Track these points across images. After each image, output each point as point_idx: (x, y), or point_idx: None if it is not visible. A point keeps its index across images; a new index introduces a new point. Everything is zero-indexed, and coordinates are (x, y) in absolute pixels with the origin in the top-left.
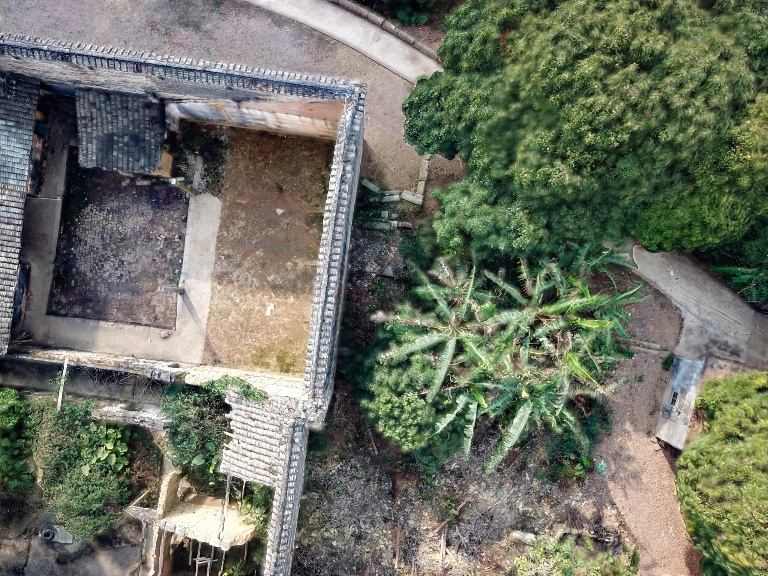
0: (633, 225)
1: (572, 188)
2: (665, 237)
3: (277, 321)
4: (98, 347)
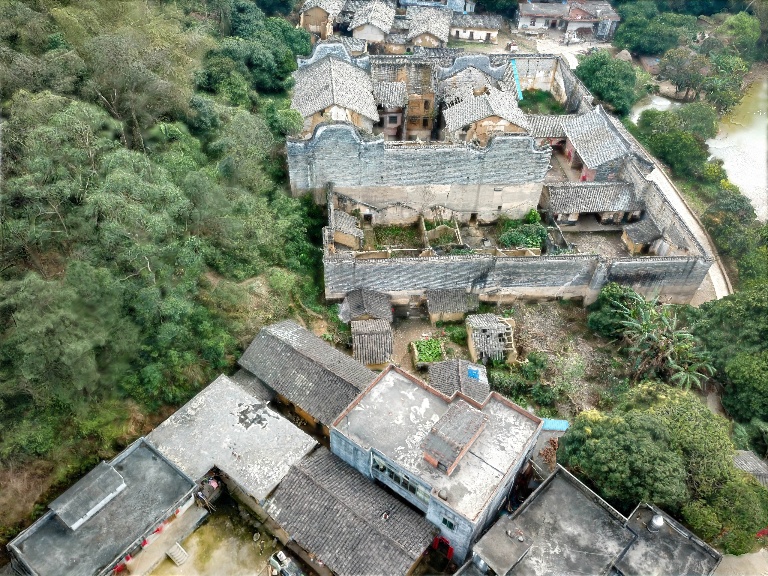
0: (730, 359)
1: (729, 312)
2: (734, 366)
3: None
4: None
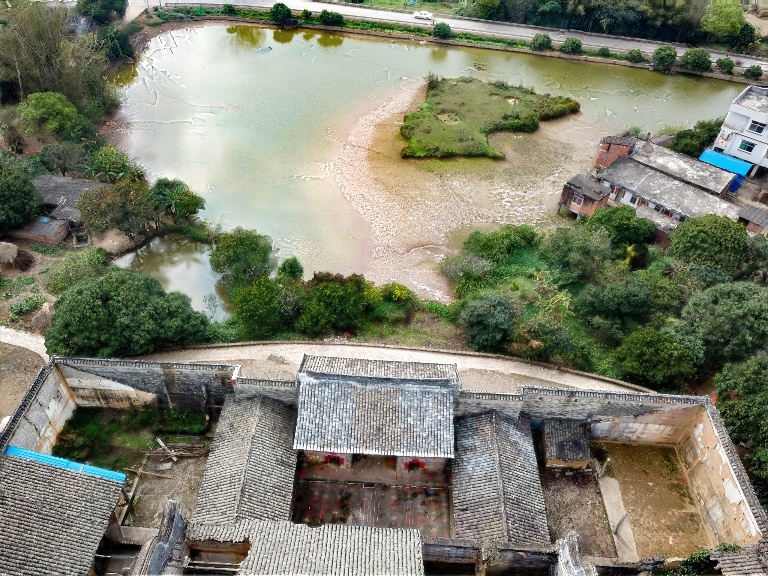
0: None
1: None
2: None
3: (678, 547)
4: None
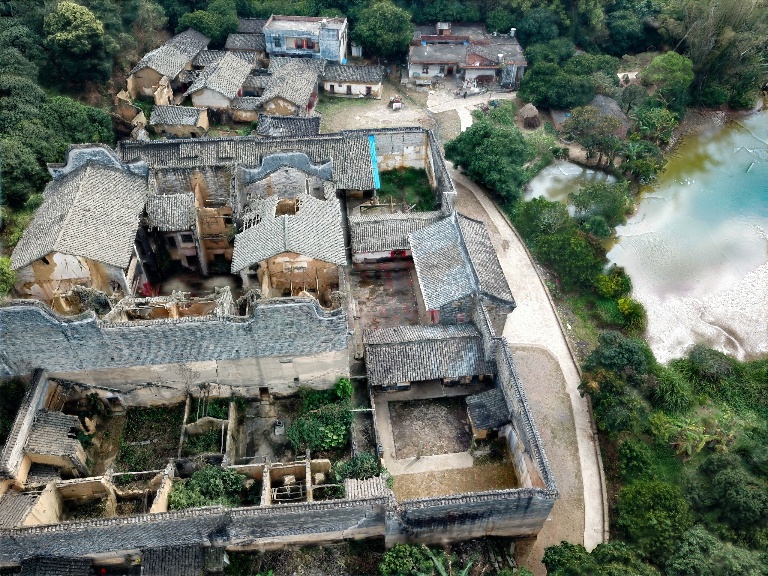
0: None
1: None
2: None
3: None
4: (378, 426)
